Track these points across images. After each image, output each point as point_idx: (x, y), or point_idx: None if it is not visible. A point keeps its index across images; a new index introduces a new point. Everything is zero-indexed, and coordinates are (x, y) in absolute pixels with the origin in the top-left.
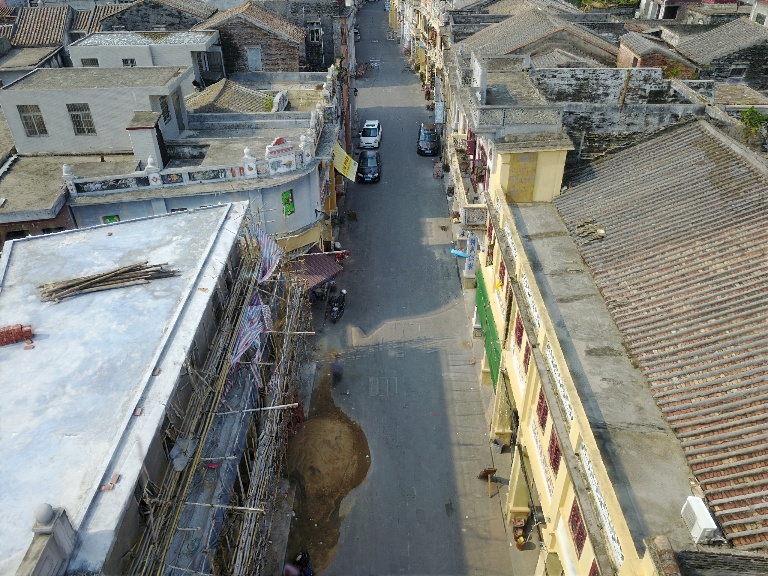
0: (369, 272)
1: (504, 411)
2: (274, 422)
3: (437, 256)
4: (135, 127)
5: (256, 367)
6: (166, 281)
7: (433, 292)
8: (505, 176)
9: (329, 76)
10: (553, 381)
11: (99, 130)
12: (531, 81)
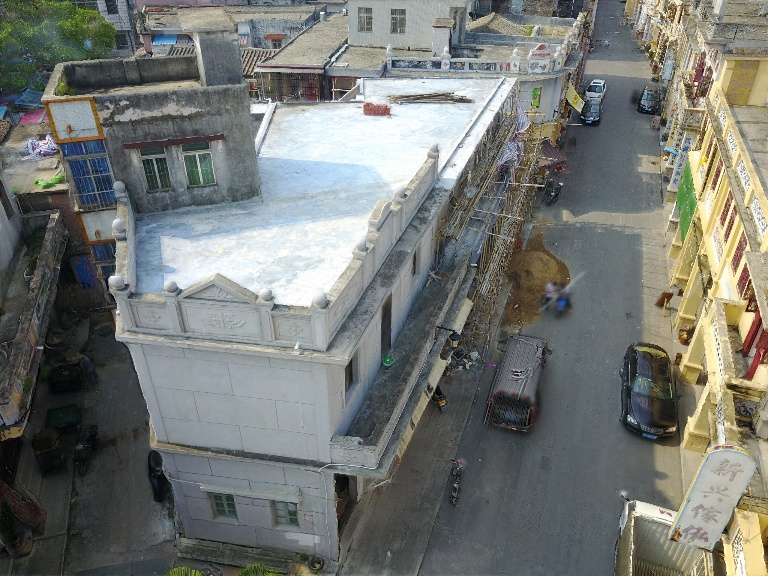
0: (582, 181)
1: (689, 250)
2: (517, 212)
3: (644, 179)
4: (439, 26)
5: (514, 170)
6: (466, 104)
7: (636, 200)
8: (727, 80)
9: (579, 18)
10: (739, 180)
11: (408, 31)
12: (766, 21)
